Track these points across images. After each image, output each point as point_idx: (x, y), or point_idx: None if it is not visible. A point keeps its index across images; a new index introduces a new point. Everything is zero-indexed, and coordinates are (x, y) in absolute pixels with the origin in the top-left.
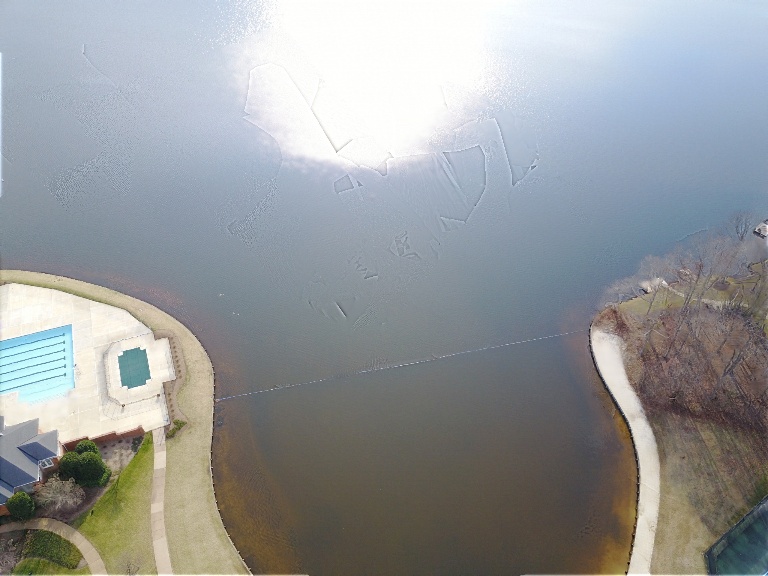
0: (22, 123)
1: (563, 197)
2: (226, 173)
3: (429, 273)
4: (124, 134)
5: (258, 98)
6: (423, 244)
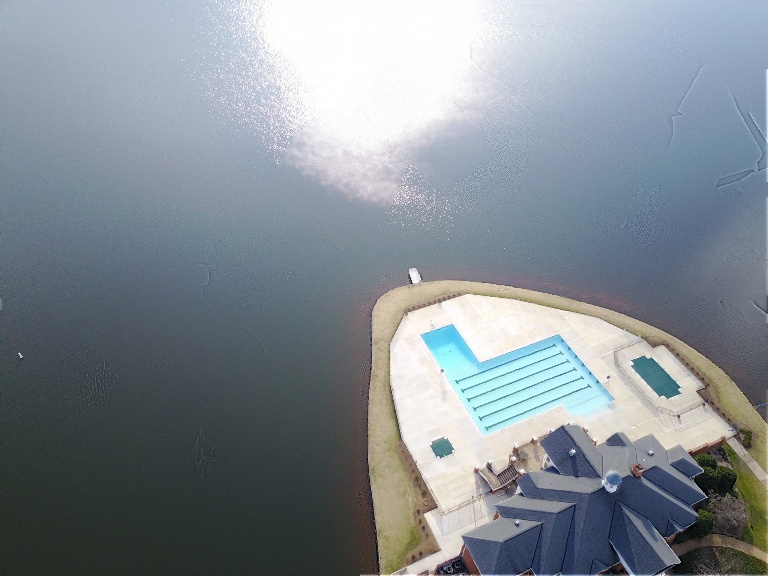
0: (425, 131)
1: None
2: (614, 173)
3: None
4: (524, 138)
5: (705, 97)
6: None
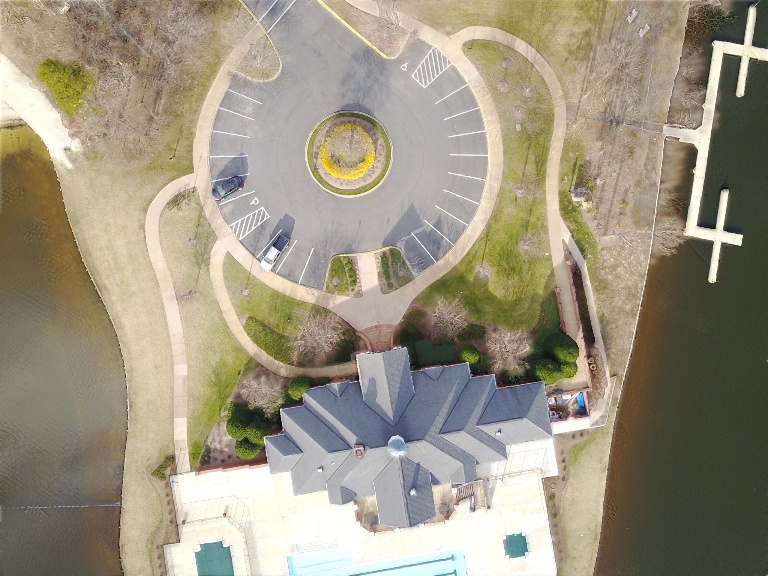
0: None
1: None
2: None
3: None
4: None
5: None
6: None
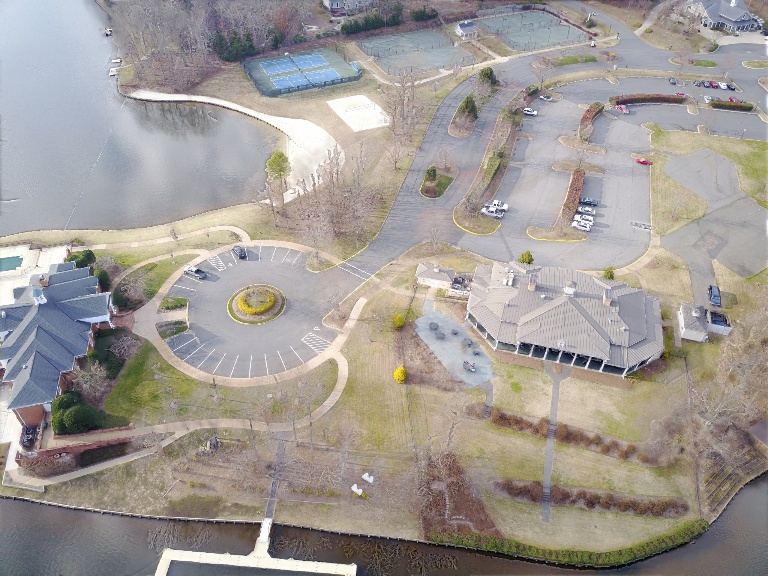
0: None
1: (17, 67)
2: None
3: (21, 146)
4: None
5: None
6: None
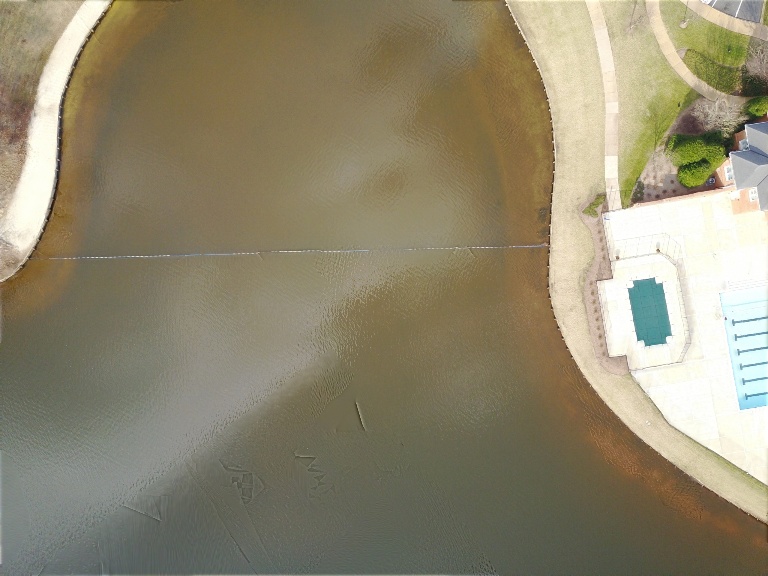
0: None
1: None
2: None
3: (216, 439)
4: None
5: None
6: (209, 476)
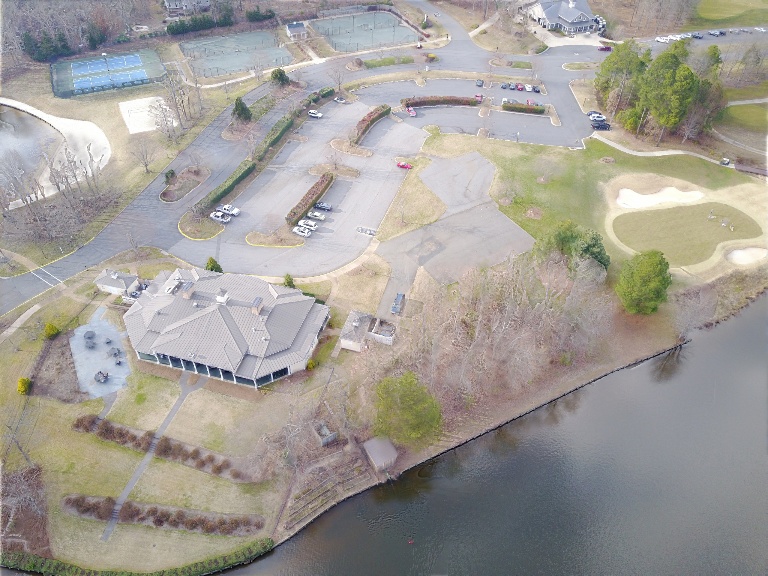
0: None
1: None
2: None
3: None
4: None
5: None
6: None
